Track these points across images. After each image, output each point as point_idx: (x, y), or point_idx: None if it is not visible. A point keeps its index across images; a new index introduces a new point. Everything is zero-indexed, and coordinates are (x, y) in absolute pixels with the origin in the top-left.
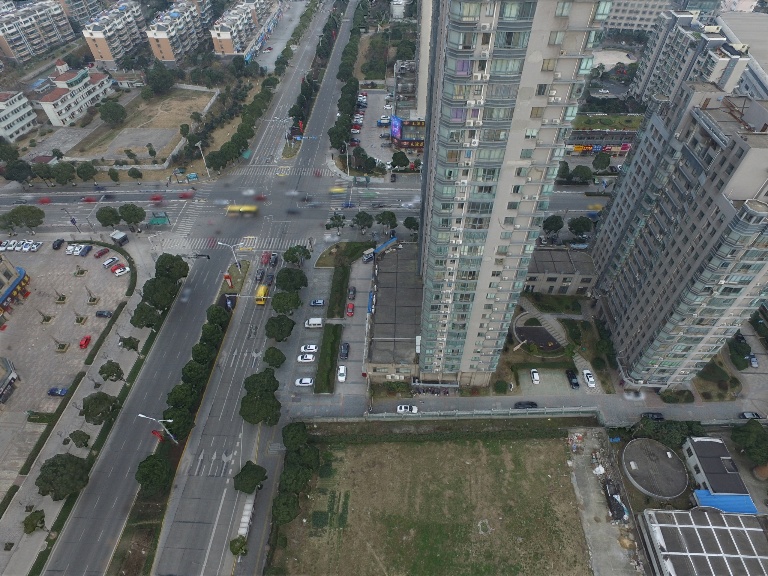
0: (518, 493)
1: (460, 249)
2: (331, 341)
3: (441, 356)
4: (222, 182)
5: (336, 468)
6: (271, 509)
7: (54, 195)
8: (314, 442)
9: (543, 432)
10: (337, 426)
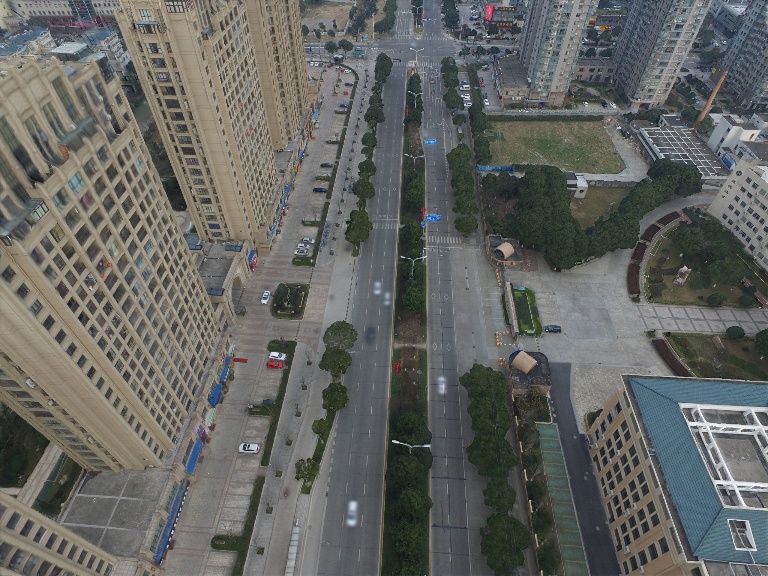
0: (581, 134)
1: None
2: (477, 93)
3: (544, 77)
4: (383, 41)
5: (494, 127)
6: (468, 135)
7: None
8: None
9: (592, 115)
10: None
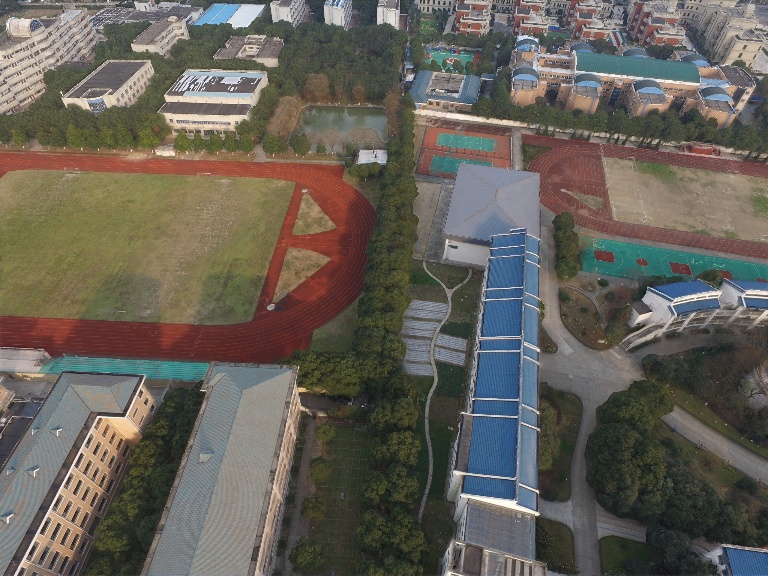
0: None
1: None
2: None
3: None
4: None
5: None
6: None
7: None
8: (22, 8)
9: (96, 5)
10: None
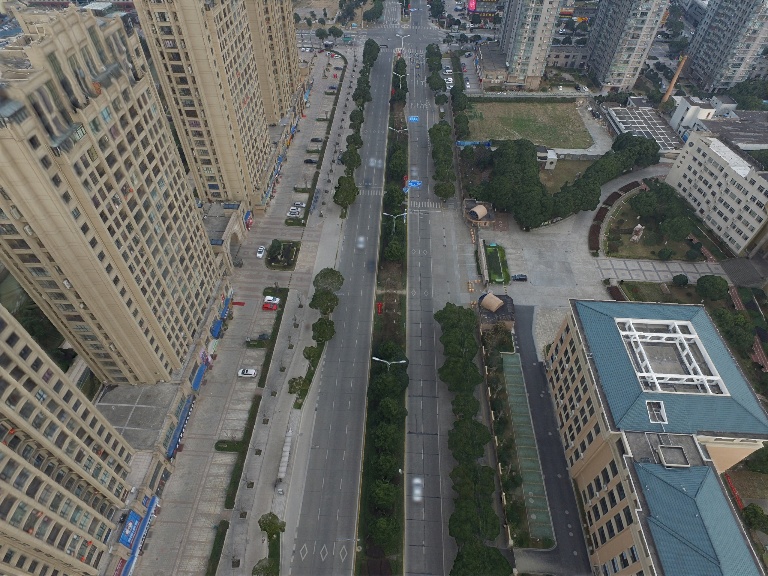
0: (555, 114)
1: None
2: (459, 77)
3: (520, 62)
4: (371, 30)
5: (474, 107)
6: None
7: None
8: None
9: (565, 97)
10: None
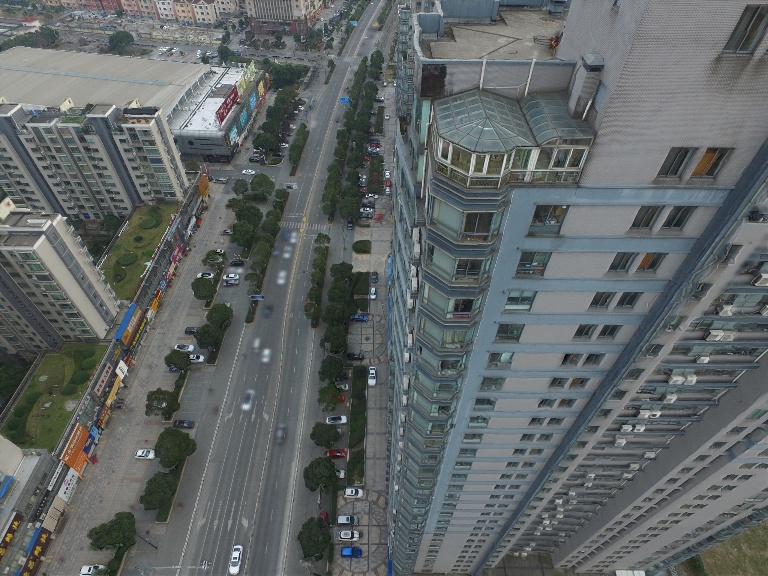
0: None
1: None
2: None
3: None
4: None
5: None
6: None
7: None
8: None
9: None
10: None
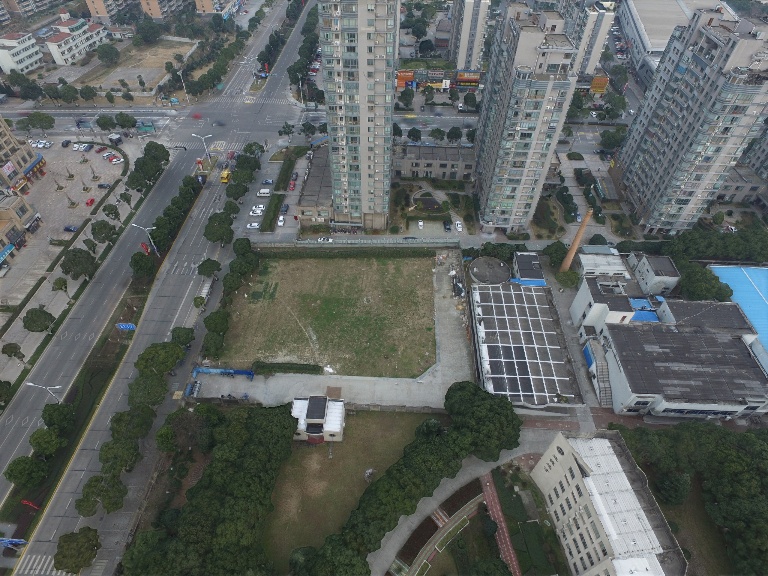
0: (394, 284)
1: (344, 98)
2: (275, 203)
3: (346, 196)
4: (199, 106)
5: (271, 271)
6: None
7: (61, 112)
8: None
9: (417, 251)
10: (274, 249)
